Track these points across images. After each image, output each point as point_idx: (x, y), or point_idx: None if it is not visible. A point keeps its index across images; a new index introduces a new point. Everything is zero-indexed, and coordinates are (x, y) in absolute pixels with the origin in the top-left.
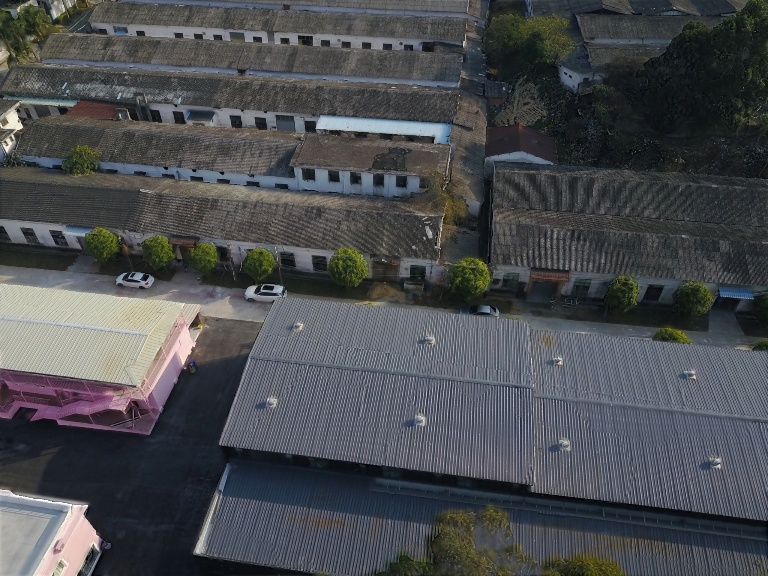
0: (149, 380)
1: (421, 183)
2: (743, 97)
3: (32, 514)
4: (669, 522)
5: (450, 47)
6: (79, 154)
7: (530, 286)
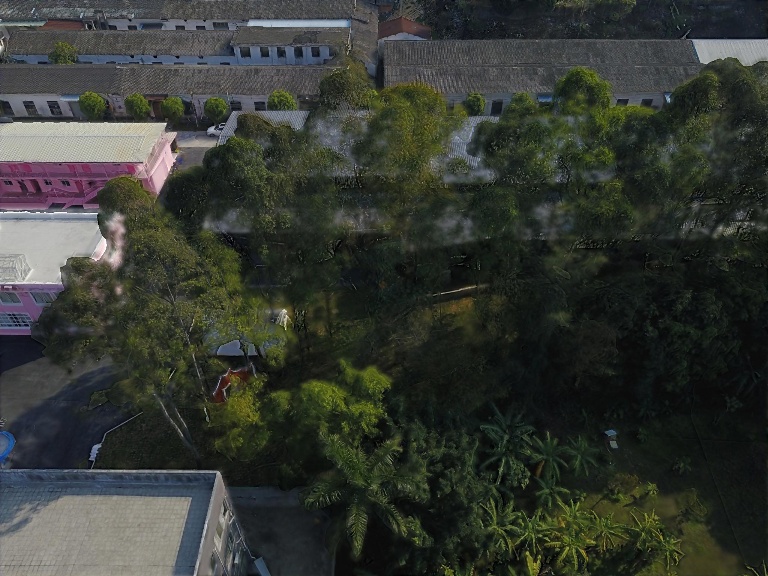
0: (149, 166)
1: (330, 52)
2: None
3: (89, 221)
4: None
5: None
6: (61, 49)
7: None
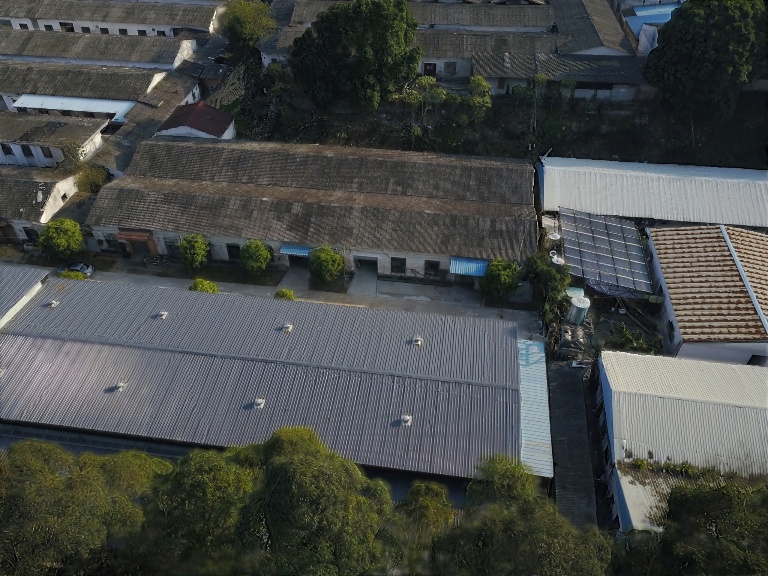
0: None
1: (64, 153)
2: (378, 74)
3: None
4: (67, 438)
5: (196, 33)
6: None
7: (130, 246)
